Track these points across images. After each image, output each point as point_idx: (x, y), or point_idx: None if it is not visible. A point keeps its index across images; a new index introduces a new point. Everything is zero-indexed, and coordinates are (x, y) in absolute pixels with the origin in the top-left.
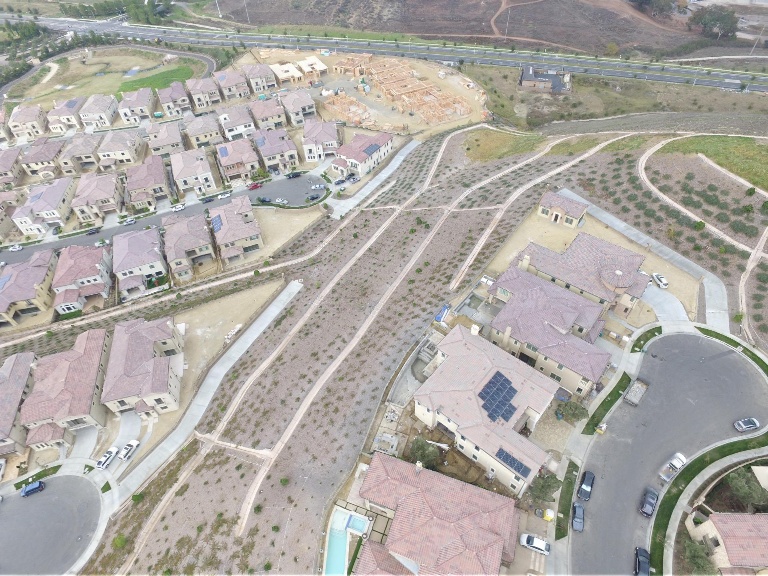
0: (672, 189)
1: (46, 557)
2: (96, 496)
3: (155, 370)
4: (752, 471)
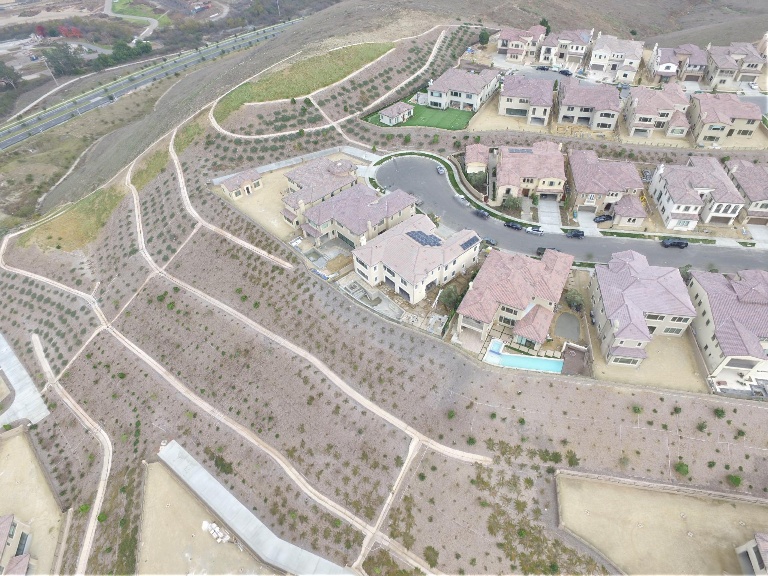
0: (263, 129)
1: None
2: None
3: None
4: None
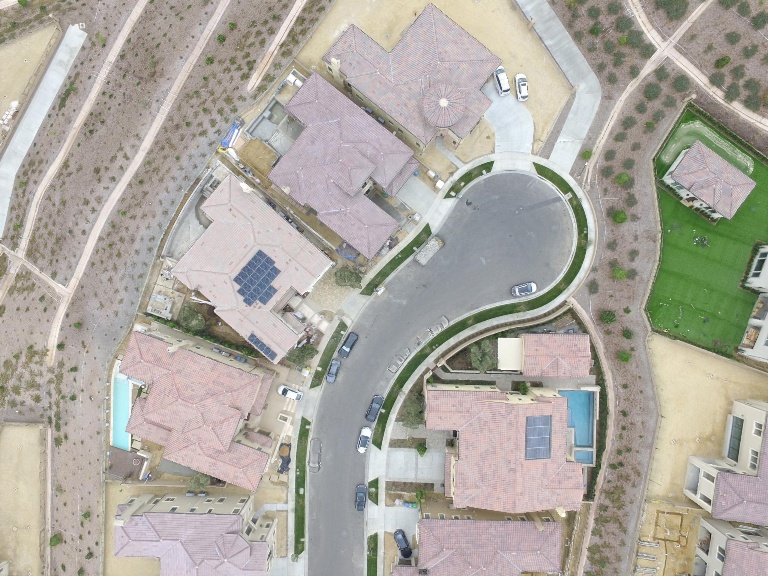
0: None
1: None
2: None
3: None
4: (497, 342)
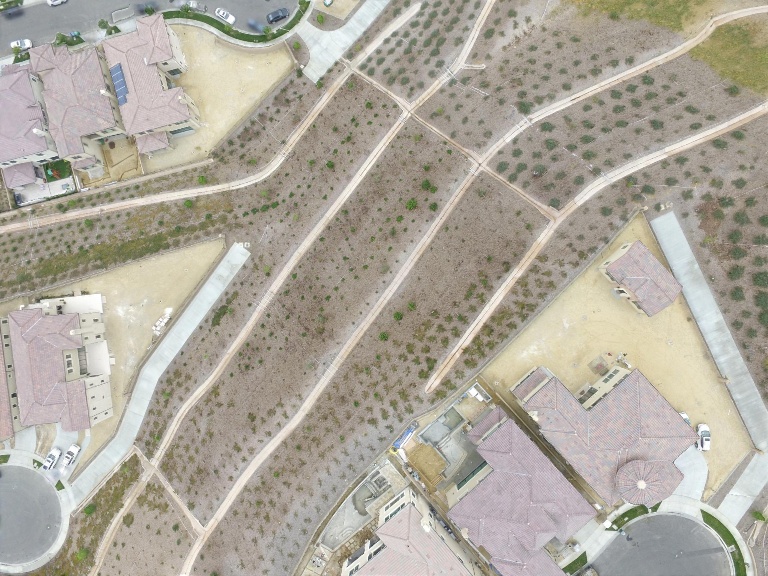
0: None
1: (25, 538)
2: (52, 492)
3: (70, 402)
4: None
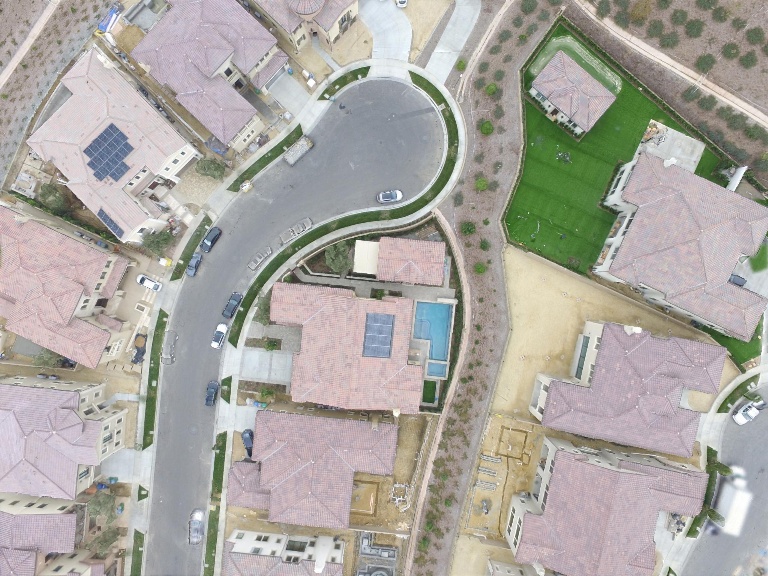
0: None
1: None
2: None
3: None
4: (354, 244)
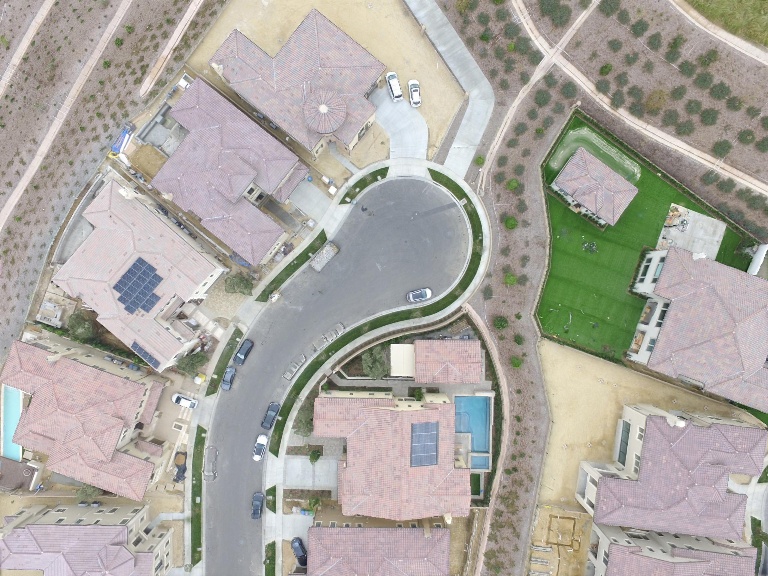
0: None
1: None
2: None
3: None
4: (389, 348)
